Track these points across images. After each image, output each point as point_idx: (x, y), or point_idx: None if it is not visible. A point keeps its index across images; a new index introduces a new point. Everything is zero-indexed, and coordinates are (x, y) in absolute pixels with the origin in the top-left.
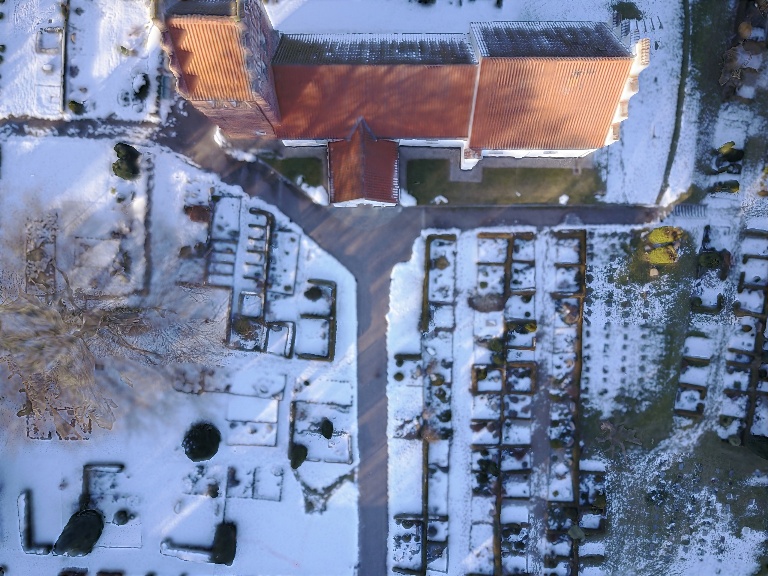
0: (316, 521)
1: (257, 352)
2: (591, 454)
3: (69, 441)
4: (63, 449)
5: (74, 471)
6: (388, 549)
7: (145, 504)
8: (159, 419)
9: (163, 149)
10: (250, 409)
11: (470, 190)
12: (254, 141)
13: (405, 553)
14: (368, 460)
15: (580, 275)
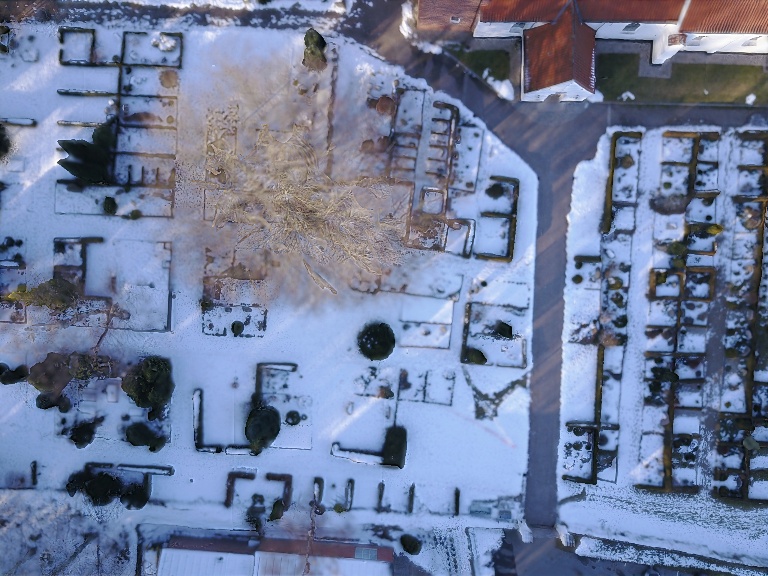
0: (486, 427)
1: (435, 251)
2: (765, 365)
3: (244, 338)
4: (237, 346)
5: (247, 369)
6: (558, 457)
7: (316, 405)
8: (333, 318)
9: (347, 40)
10: (425, 310)
11: (658, 86)
12: (441, 32)
13: (576, 461)
14: (542, 365)
15: (764, 178)
